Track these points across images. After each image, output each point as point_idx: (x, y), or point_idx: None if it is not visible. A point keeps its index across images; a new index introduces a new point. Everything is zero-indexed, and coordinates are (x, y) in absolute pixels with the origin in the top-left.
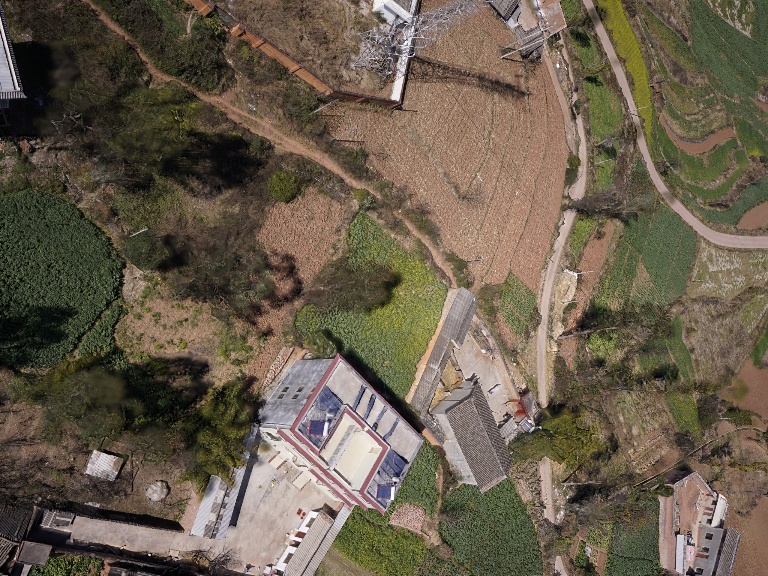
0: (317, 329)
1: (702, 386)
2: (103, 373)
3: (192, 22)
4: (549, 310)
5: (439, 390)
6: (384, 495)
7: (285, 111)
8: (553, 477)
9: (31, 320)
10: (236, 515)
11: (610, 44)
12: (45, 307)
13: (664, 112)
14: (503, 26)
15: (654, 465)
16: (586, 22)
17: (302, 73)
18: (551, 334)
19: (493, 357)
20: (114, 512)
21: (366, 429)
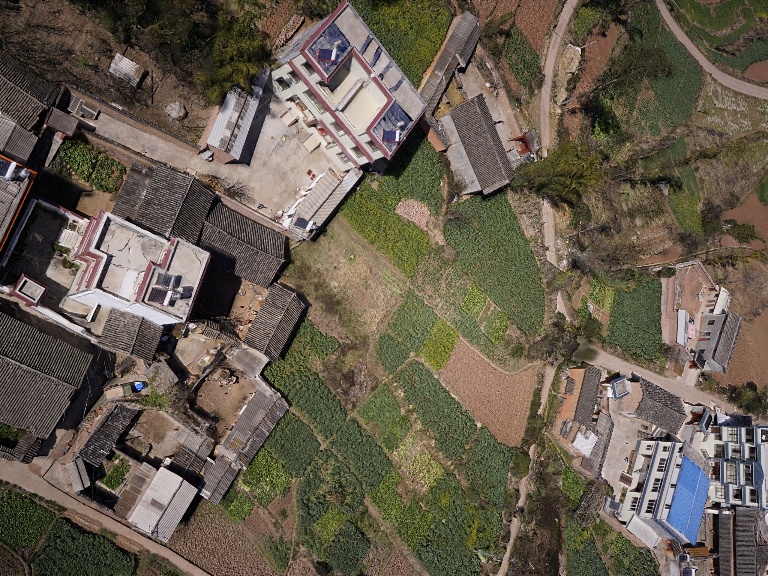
0: None
1: (702, 151)
2: None
3: None
4: (553, 76)
5: (444, 105)
6: (389, 138)
7: None
8: (556, 229)
9: None
10: (249, 156)
11: None
12: None
13: None
14: None
15: (657, 255)
16: None
17: None
18: (555, 99)
19: (497, 93)
20: None
21: (372, 76)
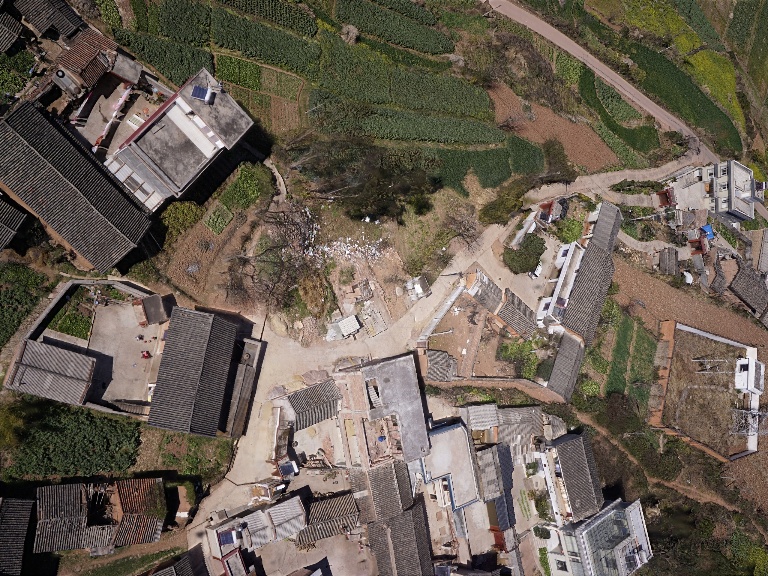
0: None
1: None
2: None
3: (664, 441)
4: None
5: None
6: None
7: (703, 478)
8: None
9: None
10: None
11: None
12: None
13: None
14: None
15: None
16: None
17: (714, 454)
18: None
19: None
20: None
21: None
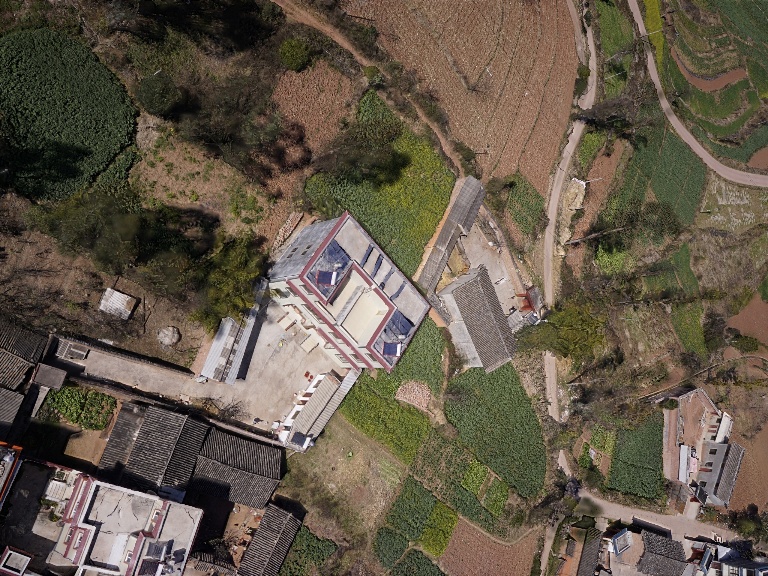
0: None
1: (708, 293)
2: (117, 213)
3: None
4: (557, 216)
5: (446, 275)
6: (390, 352)
7: None
8: (558, 377)
9: (47, 153)
10: (245, 369)
11: None
12: (61, 142)
13: (676, 47)
14: None
15: (659, 381)
16: None
17: None
18: (558, 239)
19: (500, 251)
20: (127, 351)
21: (373, 287)
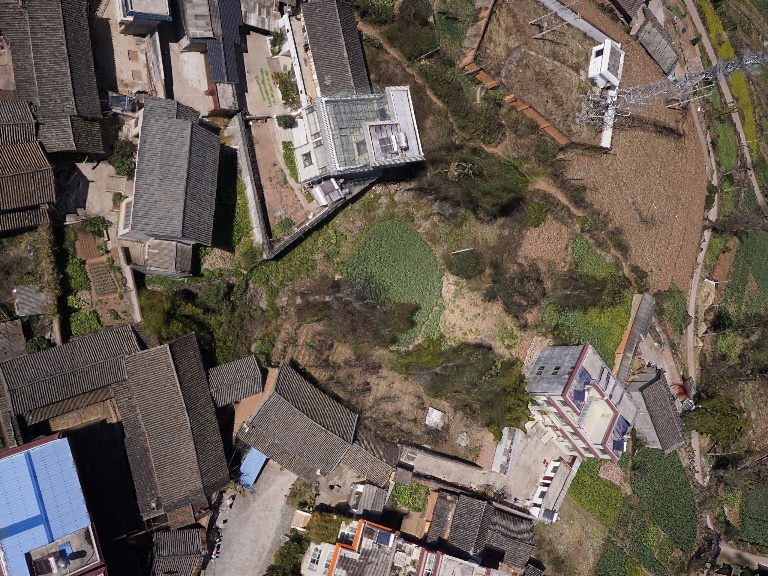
0: (555, 323)
1: None
2: None
3: (481, 93)
4: (695, 312)
5: None
6: (618, 448)
7: (536, 158)
8: (701, 448)
9: (397, 312)
10: None
11: (726, 85)
12: (404, 303)
13: None
14: (667, 81)
15: None
16: None
17: (550, 129)
18: (697, 332)
19: (662, 349)
20: (439, 453)
21: (605, 398)
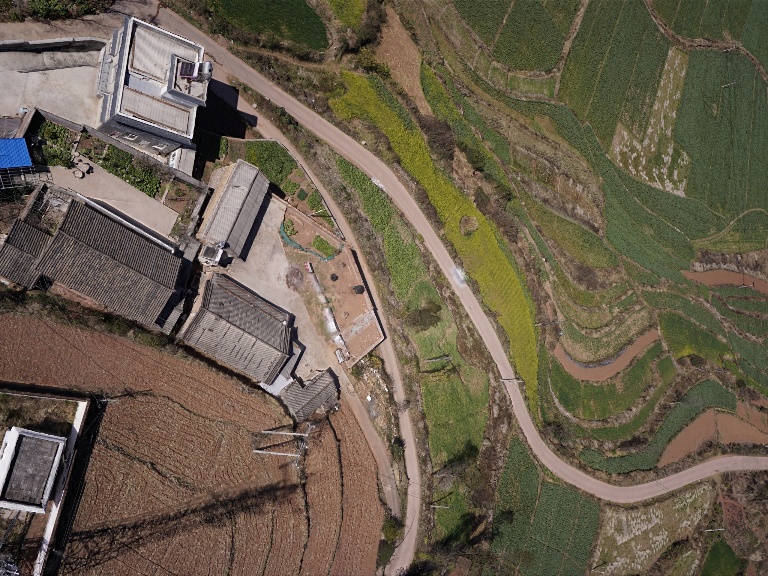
0: None
1: None
2: None
3: None
4: None
5: None
6: None
7: None
8: None
9: None
10: None
11: (474, 299)
12: None
13: (563, 338)
14: (261, 400)
15: None
16: (437, 283)
17: None
18: None
19: None
20: None
21: None
